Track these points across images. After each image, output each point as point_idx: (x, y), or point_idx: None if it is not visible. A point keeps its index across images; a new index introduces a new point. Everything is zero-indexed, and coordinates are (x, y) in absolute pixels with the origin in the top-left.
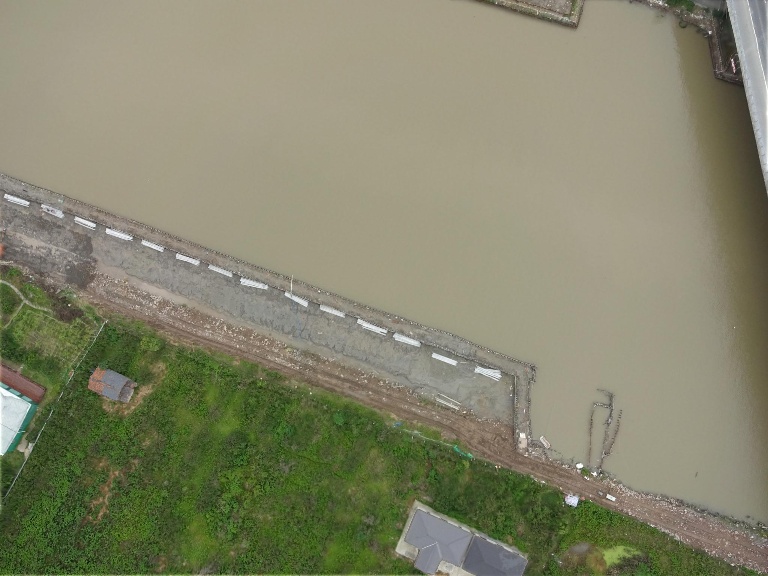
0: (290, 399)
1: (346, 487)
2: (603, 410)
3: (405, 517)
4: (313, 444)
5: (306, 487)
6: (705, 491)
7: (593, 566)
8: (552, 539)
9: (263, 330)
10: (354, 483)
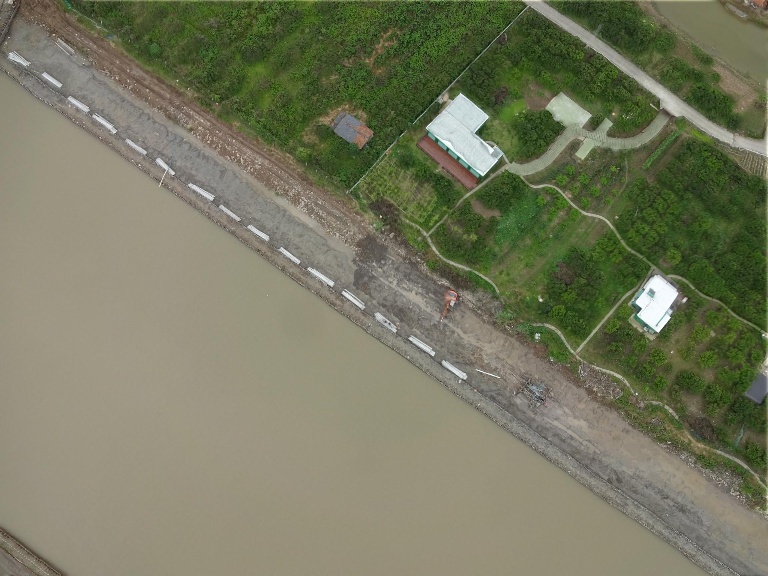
0: None
1: None
2: None
3: None
4: (187, 37)
5: (202, 6)
6: None
7: None
8: None
9: (210, 152)
10: None
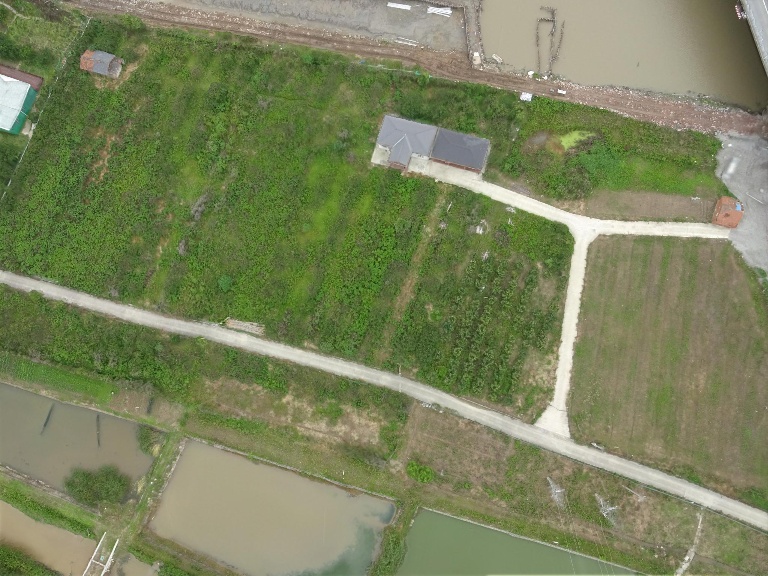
0: (263, 54)
1: (321, 116)
2: (547, 24)
3: (377, 132)
4: (287, 86)
5: (284, 120)
6: (647, 76)
7: (552, 151)
8: (511, 127)
9: (234, 12)
10: (327, 111)
